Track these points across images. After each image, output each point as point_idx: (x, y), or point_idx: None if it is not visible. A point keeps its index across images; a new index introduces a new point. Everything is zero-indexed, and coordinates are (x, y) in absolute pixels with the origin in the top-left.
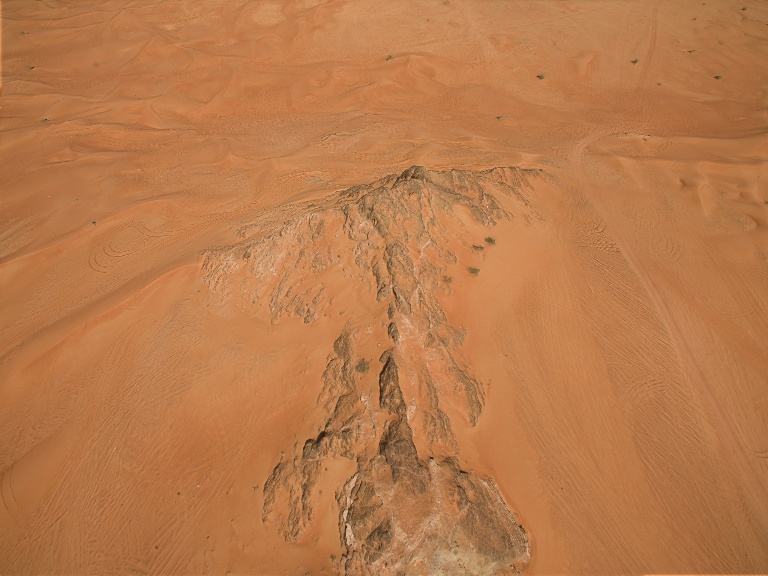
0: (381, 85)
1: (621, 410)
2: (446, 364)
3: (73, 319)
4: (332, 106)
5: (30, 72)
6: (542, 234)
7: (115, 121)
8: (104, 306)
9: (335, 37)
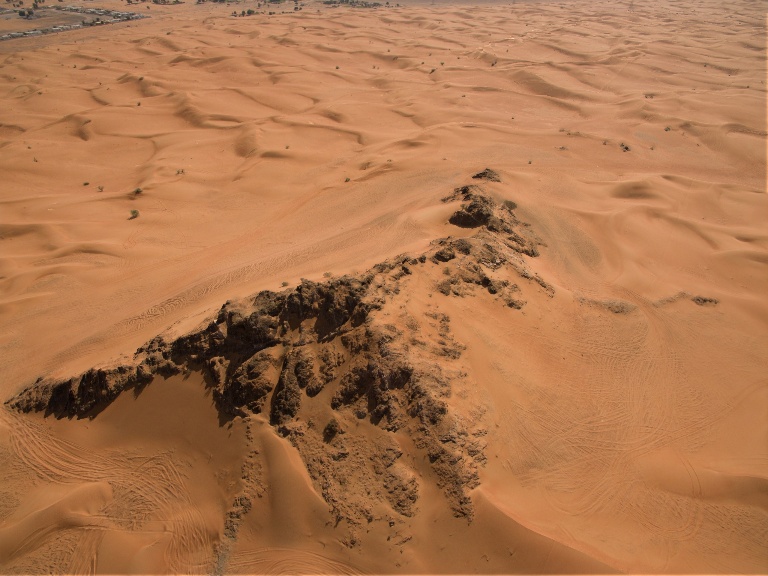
0: None
1: None
2: None
3: None
4: None
5: None
6: None
7: None
8: (604, 574)
9: None
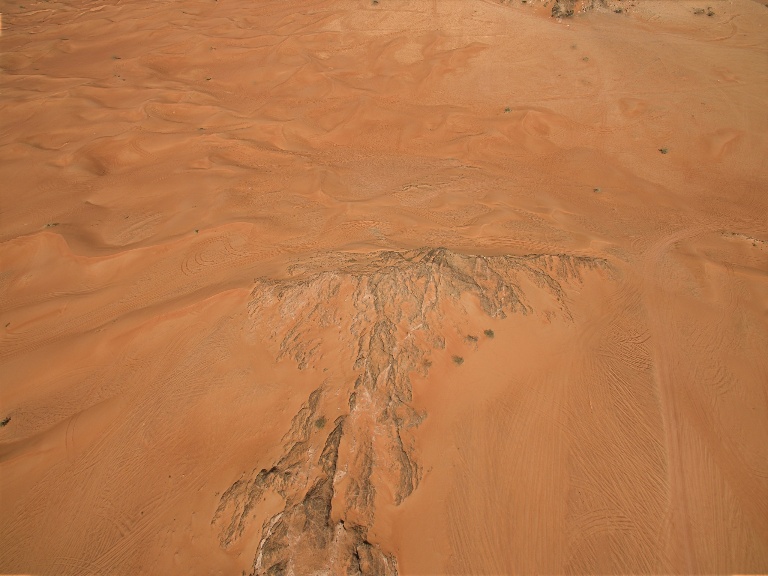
0: (489, 137)
1: (566, 536)
2: (391, 442)
3: (153, 310)
4: (436, 151)
5: (206, 83)
6: (560, 334)
7: (251, 137)
8: (176, 306)
9: (462, 82)
